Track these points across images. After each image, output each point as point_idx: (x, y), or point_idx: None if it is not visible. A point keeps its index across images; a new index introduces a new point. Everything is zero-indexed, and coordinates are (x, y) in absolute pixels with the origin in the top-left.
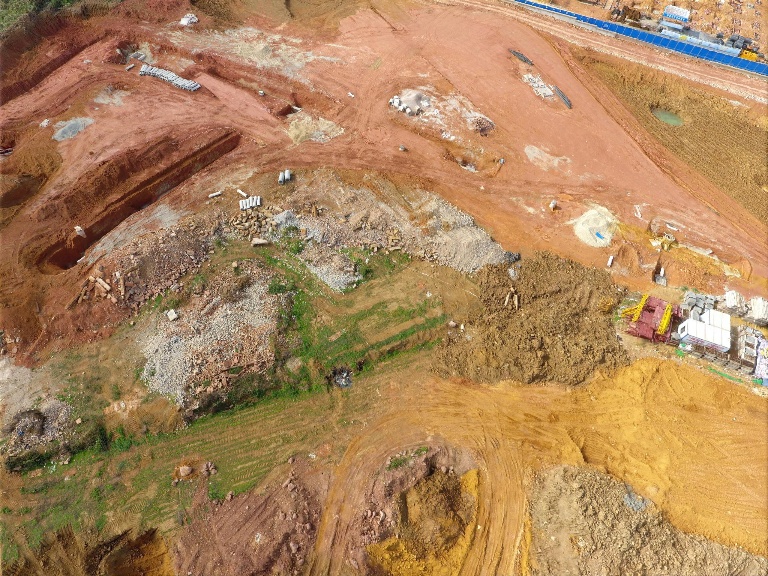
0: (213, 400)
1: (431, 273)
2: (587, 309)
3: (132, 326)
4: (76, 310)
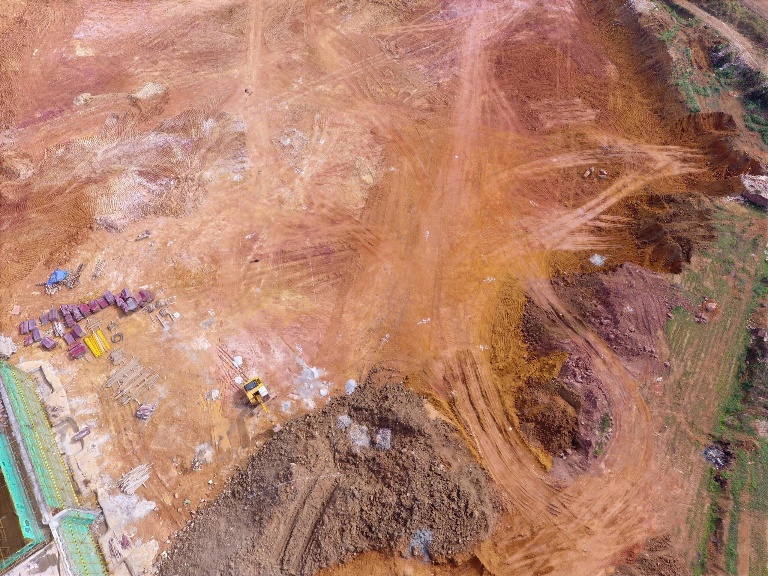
0: (765, 352)
1: None
2: None
3: None
4: None
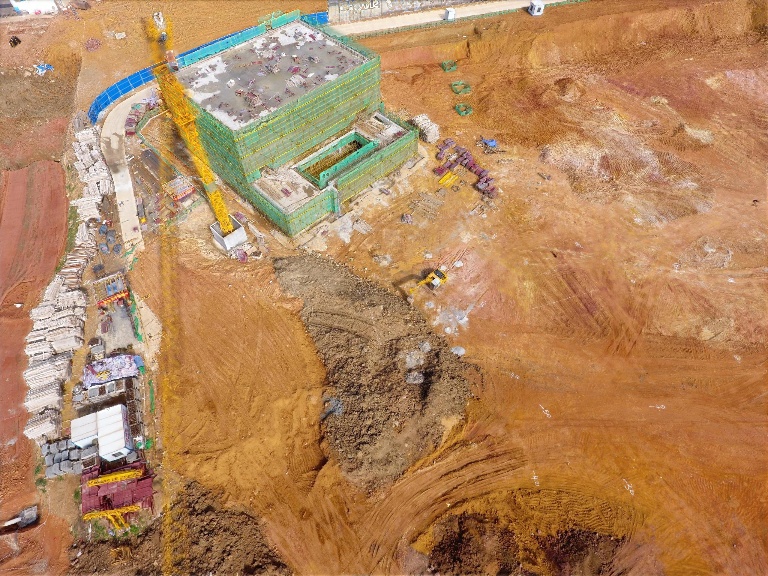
0: None
1: None
2: (137, 573)
3: None
4: None
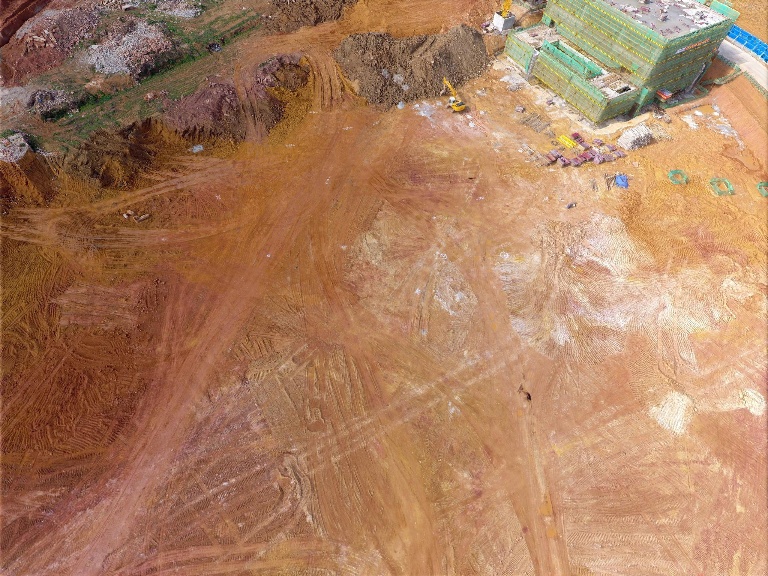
0: (147, 67)
1: (240, 1)
2: None
3: (72, 58)
4: (30, 56)
